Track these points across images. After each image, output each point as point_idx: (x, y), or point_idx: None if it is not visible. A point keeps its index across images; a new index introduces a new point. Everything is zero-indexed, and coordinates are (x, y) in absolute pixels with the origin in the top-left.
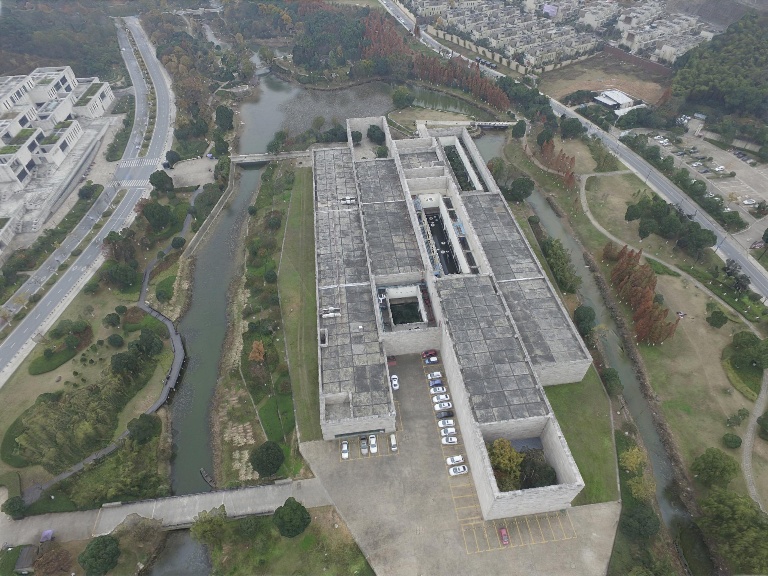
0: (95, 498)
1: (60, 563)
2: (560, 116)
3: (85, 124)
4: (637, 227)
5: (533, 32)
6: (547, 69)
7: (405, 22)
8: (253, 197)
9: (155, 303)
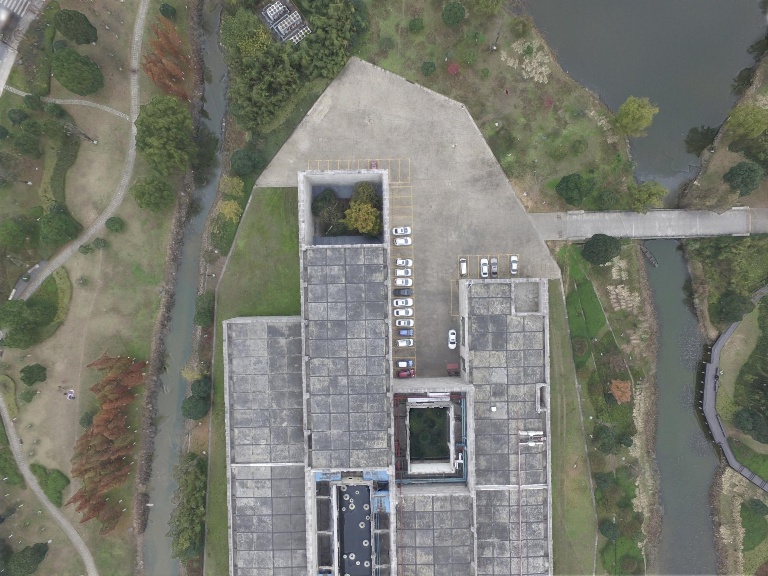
0: (760, 240)
1: None
2: None
3: None
4: (38, 575)
5: None
6: None
7: None
8: None
9: (762, 499)
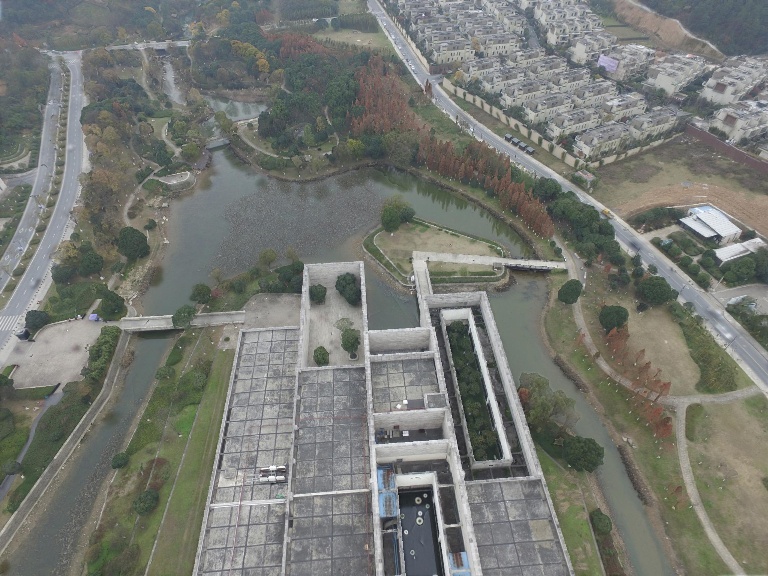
0: None
1: None
2: (630, 253)
3: None
4: None
5: (585, 99)
6: (606, 161)
7: (415, 70)
8: (137, 413)
9: None
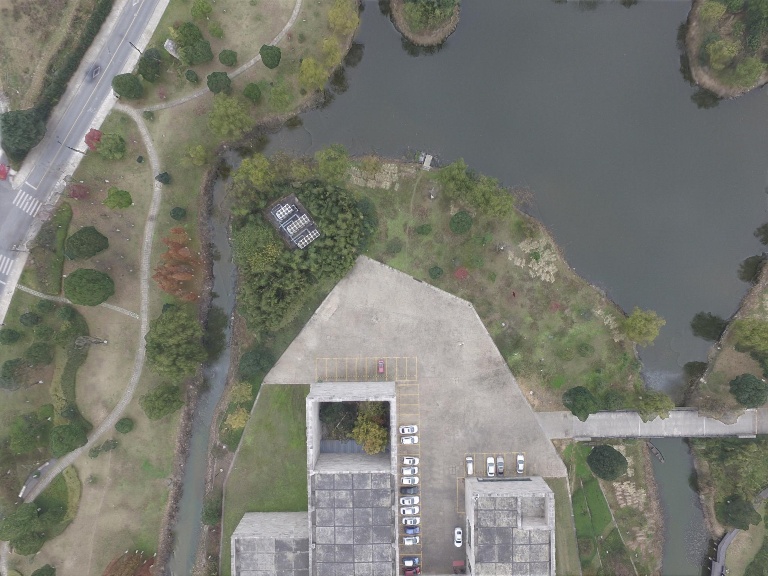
0: (766, 444)
1: None
2: None
3: None
4: None
5: None
6: None
7: None
8: None
9: None
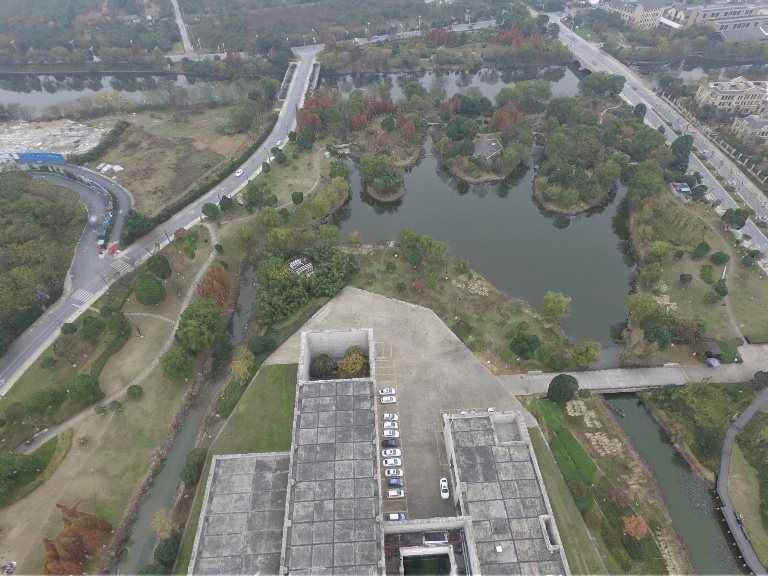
0: None
1: (679, 326)
2: None
3: None
4: None
5: None
6: None
7: None
8: None
9: None
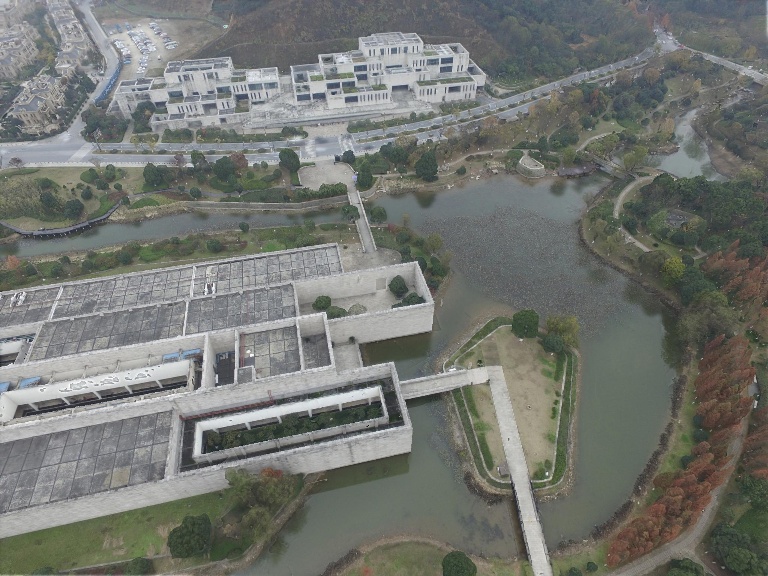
0: None
1: None
2: None
3: (405, 99)
4: None
5: None
6: None
7: None
8: (283, 226)
9: None
